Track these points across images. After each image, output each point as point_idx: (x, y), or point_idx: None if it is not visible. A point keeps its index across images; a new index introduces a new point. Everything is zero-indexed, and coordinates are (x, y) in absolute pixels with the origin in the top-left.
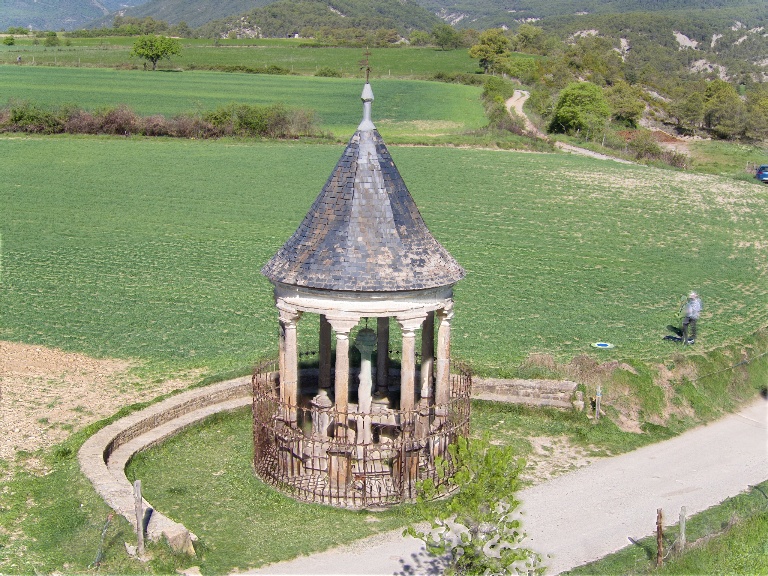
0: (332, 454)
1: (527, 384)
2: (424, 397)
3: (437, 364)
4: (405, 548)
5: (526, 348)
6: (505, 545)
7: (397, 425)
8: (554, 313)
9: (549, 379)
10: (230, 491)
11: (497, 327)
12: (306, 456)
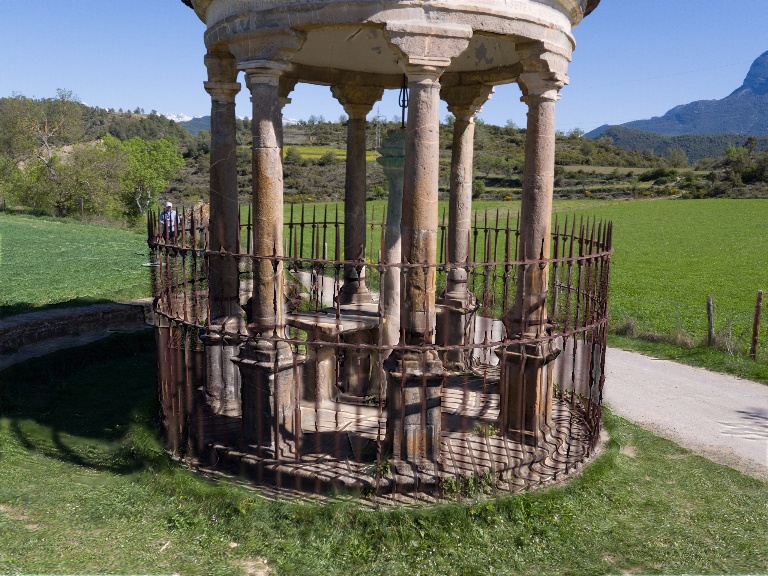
0: (547, 361)
1: (247, 287)
2: (362, 278)
3: (463, 193)
4: (759, 448)
5: (109, 274)
6: (706, 399)
7: (436, 311)
8: (6, 259)
9: (248, 280)
10: (420, 572)
11: (1, 271)
12: (334, 433)
